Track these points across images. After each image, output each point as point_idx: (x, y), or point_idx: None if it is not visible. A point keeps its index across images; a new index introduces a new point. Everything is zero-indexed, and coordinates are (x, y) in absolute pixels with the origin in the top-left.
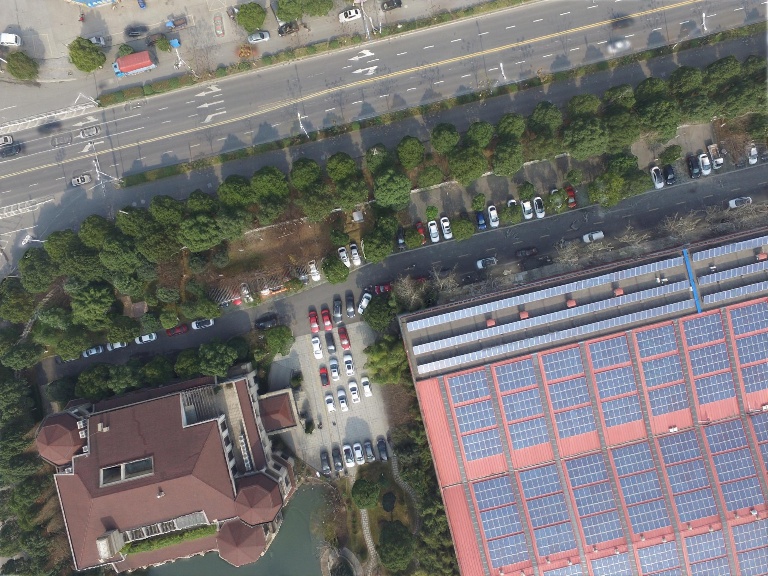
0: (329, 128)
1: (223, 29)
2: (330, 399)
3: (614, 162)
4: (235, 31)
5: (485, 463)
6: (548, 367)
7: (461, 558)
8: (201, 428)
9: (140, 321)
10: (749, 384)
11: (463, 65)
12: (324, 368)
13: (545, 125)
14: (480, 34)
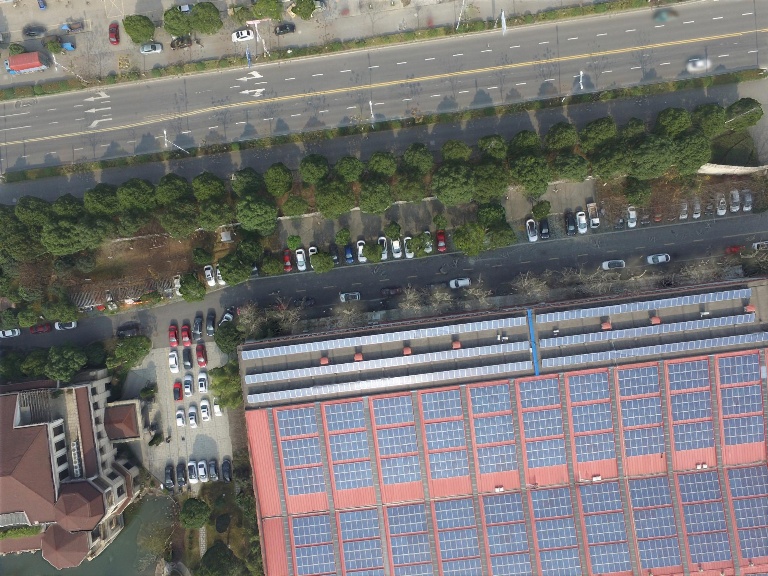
0: (209, 146)
1: (118, 37)
2: (180, 414)
3: (481, 211)
4: (130, 40)
5: (307, 499)
6: (378, 412)
7: None
8: (30, 431)
9: (0, 316)
10: (581, 453)
11: (350, 96)
12: (179, 383)
13: (413, 167)
14: (370, 67)
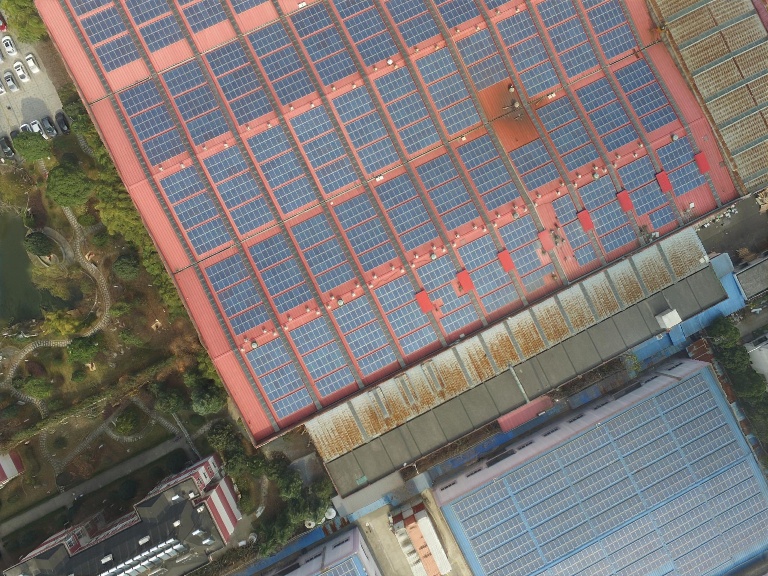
0: None
1: None
2: None
3: None
4: None
5: (126, 72)
6: None
7: (119, 165)
8: None
9: None
10: None
11: None
12: None
13: None
14: None
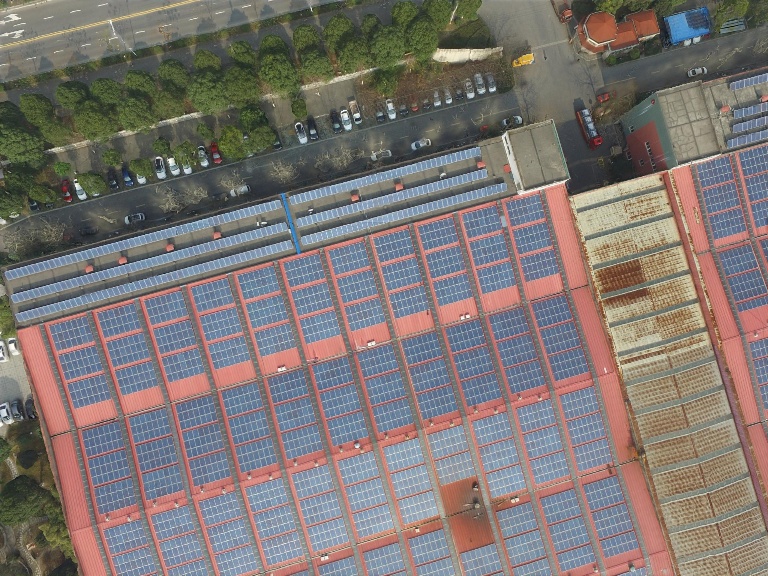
0: None
1: None
2: None
3: (240, 116)
4: None
5: (94, 410)
6: (152, 311)
7: (67, 506)
8: None
9: None
10: (353, 322)
11: (110, 28)
12: None
13: (167, 81)
14: None
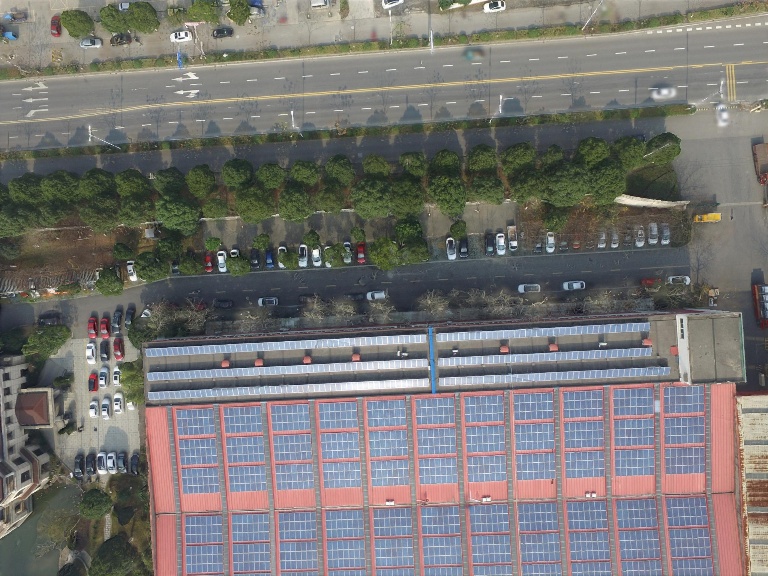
0: (141, 143)
1: (60, 29)
2: (94, 405)
3: (397, 227)
4: None
5: (201, 499)
6: (275, 418)
7: None
8: None
9: None
10: (473, 473)
11: (282, 104)
12: (95, 374)
13: (333, 178)
14: (304, 76)
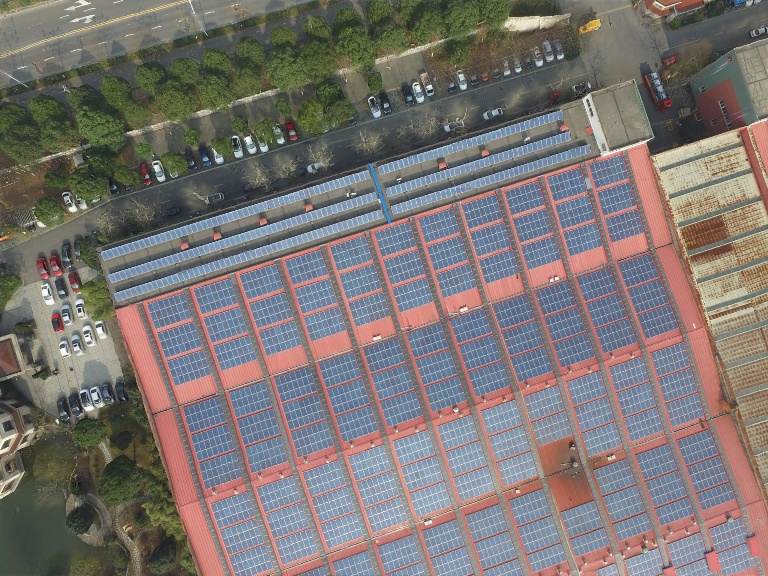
0: (48, 76)
1: None
2: (63, 344)
3: (318, 91)
4: None
5: (194, 386)
6: (247, 286)
7: (174, 482)
8: None
9: None
10: (445, 288)
11: (180, 10)
12: (56, 314)
13: (245, 58)
14: None
